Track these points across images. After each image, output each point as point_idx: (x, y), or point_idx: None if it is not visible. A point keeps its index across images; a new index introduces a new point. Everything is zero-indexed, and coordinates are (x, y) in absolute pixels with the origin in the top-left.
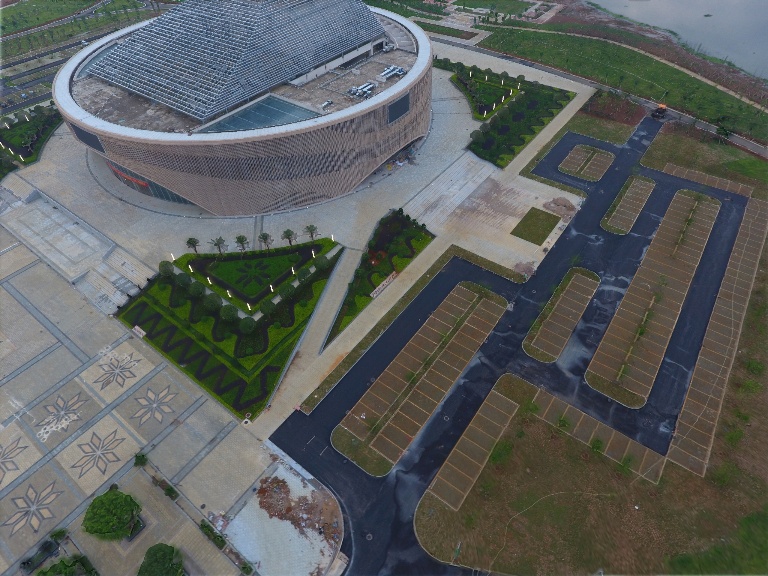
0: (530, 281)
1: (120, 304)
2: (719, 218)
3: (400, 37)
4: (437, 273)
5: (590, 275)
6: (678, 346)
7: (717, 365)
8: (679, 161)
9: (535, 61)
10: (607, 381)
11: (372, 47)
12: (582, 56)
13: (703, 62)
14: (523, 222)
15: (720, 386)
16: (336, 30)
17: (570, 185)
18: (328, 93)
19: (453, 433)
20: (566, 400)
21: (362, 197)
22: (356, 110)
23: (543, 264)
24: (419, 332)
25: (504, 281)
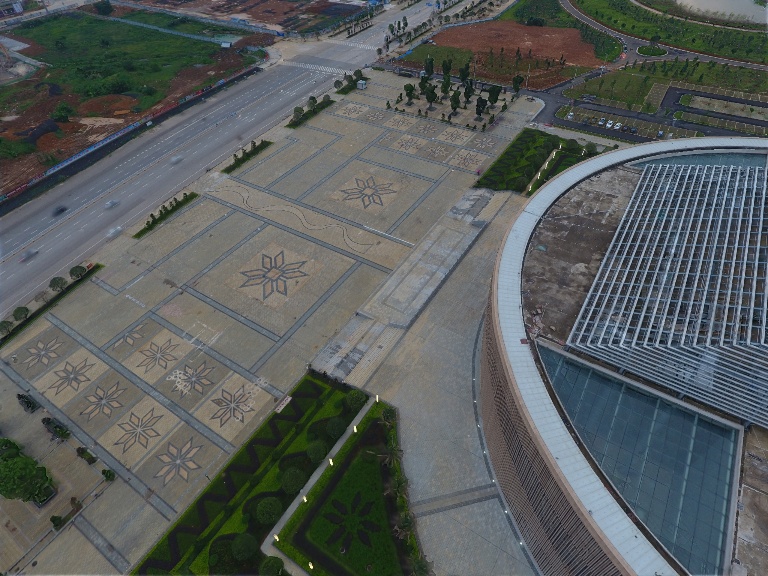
0: None
1: (325, 369)
2: None
3: None
4: None
5: None
6: None
7: None
8: None
9: None
10: None
11: None
12: None
13: None
14: None
15: None
16: None
17: None
18: None
19: None
20: None
21: None
22: None
23: None
24: None
25: None
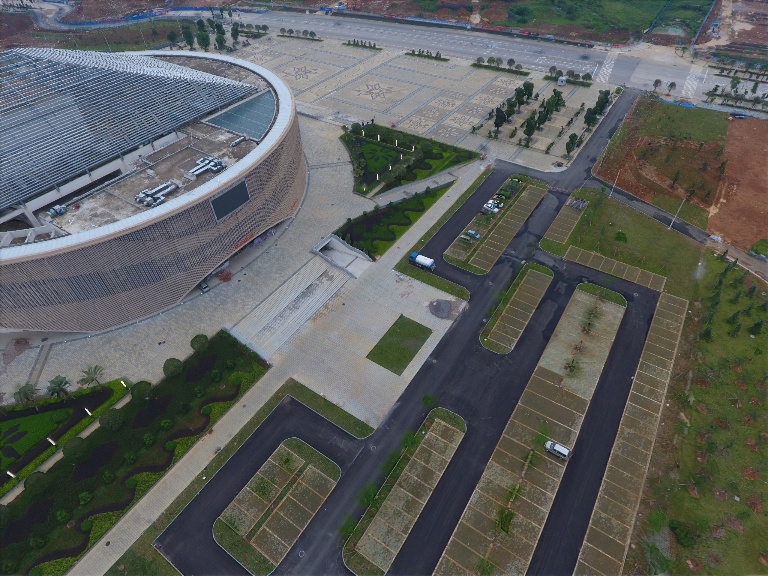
0: None
1: None
2: None
3: None
4: None
5: None
6: None
7: None
8: None
9: None
10: None
11: None
12: None
13: None
14: None
15: None
16: None
17: None
18: None
19: None
20: None
21: None
22: None
23: None
24: None
25: None
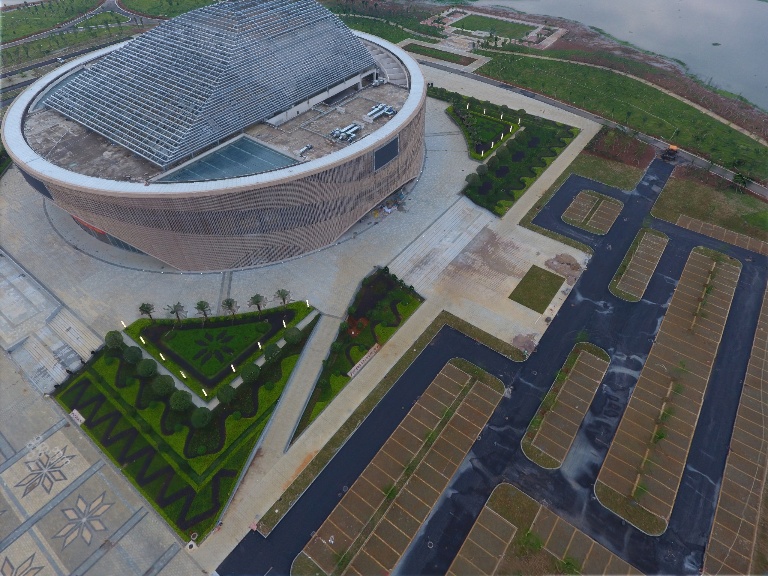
0: (530, 359)
1: (59, 380)
2: (741, 283)
3: (392, 69)
4: (425, 347)
5: (598, 353)
6: (702, 449)
7: (748, 476)
8: (693, 212)
9: (536, 91)
10: (620, 496)
11: (361, 79)
12: (586, 87)
13: (714, 96)
14: (523, 283)
15: (753, 506)
16: (321, 62)
17: (575, 239)
18: (308, 135)
19: (438, 566)
20: (572, 522)
21: (344, 250)
22: (338, 158)
23: (545, 338)
24: (402, 424)
25: (501, 359)
